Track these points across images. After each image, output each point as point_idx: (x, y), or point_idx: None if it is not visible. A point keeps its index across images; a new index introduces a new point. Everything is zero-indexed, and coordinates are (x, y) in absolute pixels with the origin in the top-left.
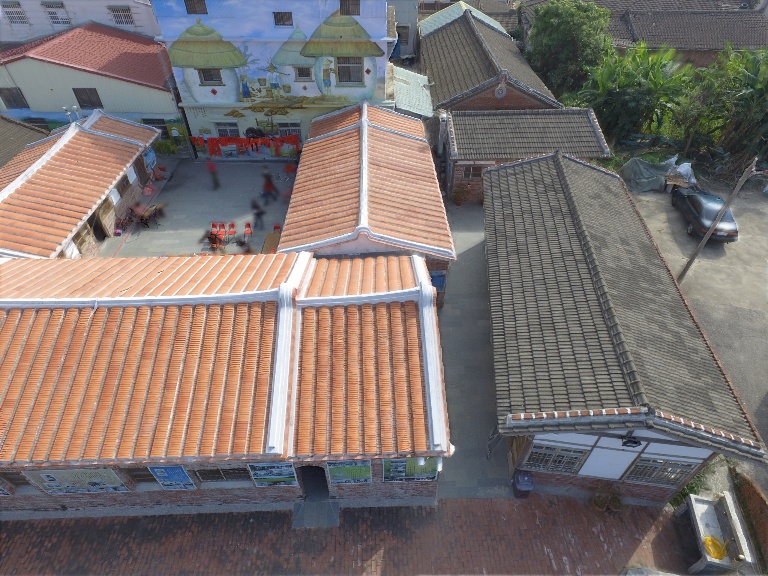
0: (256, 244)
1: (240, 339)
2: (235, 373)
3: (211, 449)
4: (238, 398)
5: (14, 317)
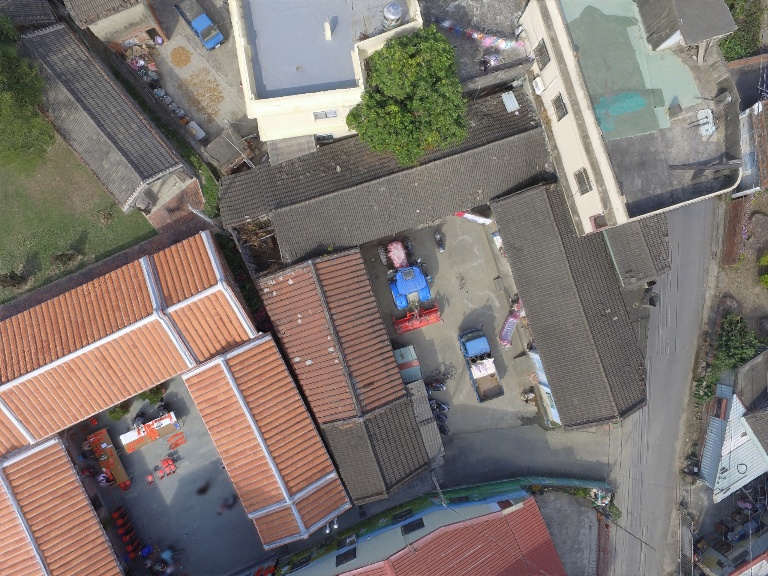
0: (145, 473)
1: (8, 365)
2: (7, 351)
3: (7, 322)
4: (3, 342)
5: (108, 331)
